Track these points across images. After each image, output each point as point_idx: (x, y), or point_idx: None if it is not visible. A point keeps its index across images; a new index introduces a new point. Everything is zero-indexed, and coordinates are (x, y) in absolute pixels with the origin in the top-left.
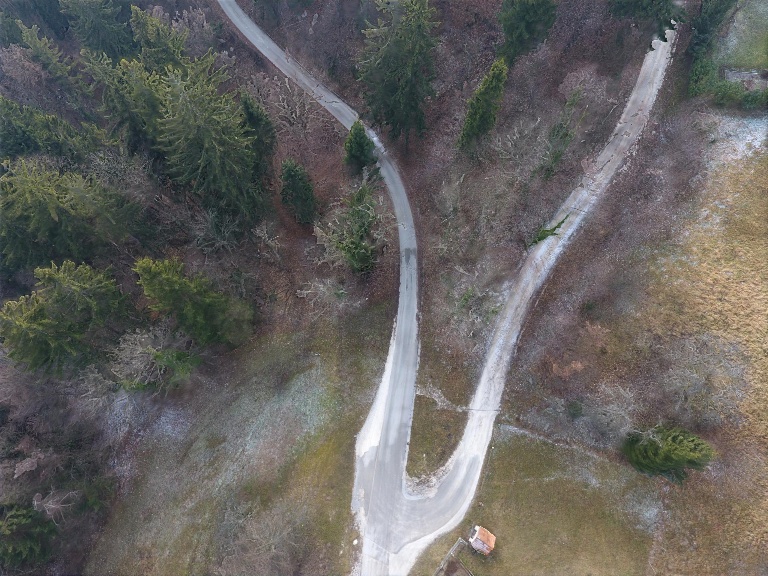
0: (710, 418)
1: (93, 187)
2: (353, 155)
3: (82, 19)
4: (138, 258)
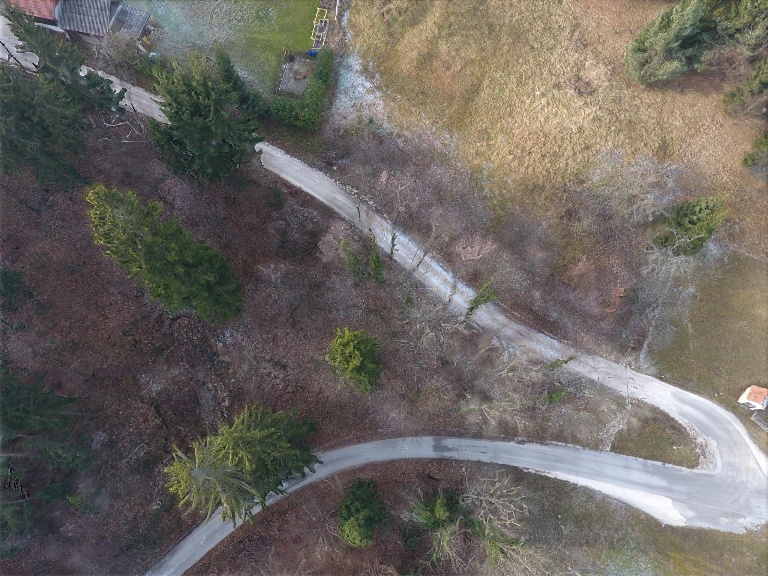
0: None
1: None
2: None
3: None
4: None
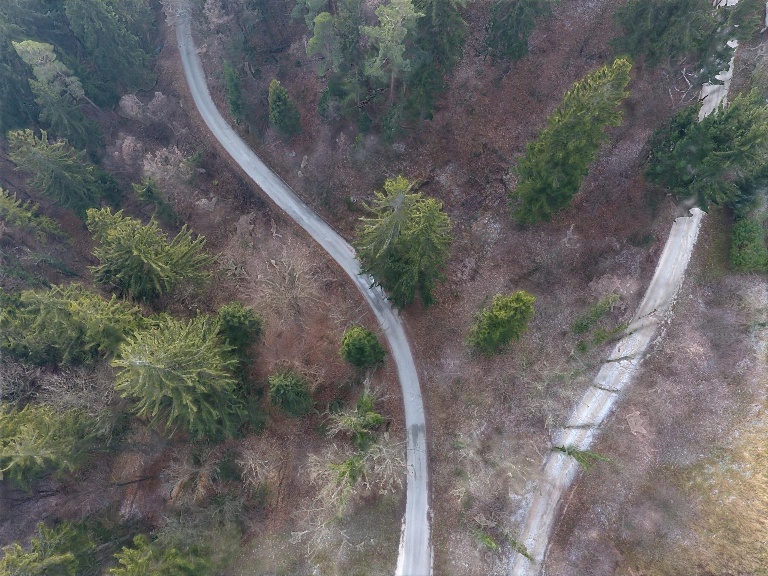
0: None
1: (44, 438)
2: None
3: (39, 176)
4: None
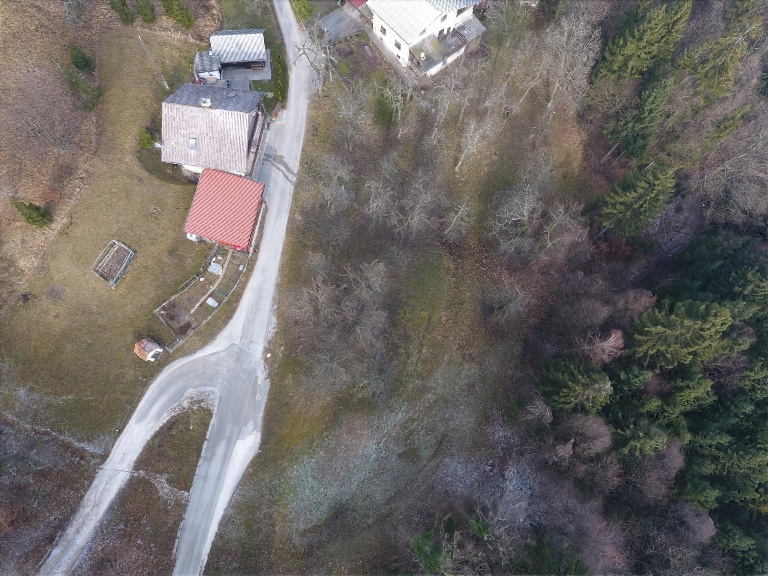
0: None
1: None
2: None
3: None
4: None
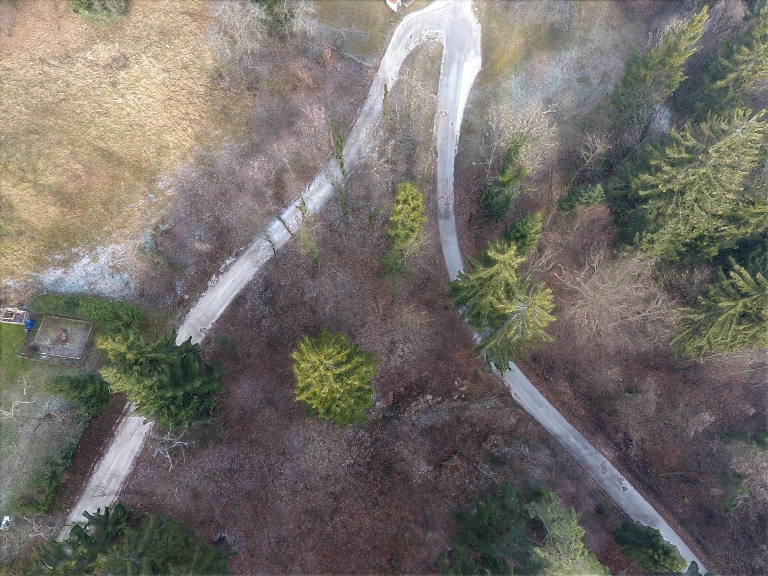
0: None
1: None
2: None
3: None
4: None
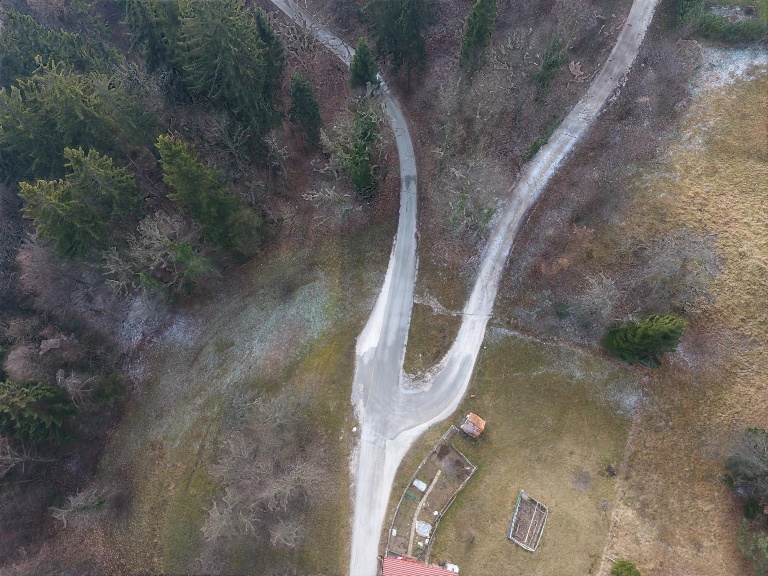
0: (687, 311)
1: (116, 89)
2: (358, 75)
3: None
4: (153, 180)
